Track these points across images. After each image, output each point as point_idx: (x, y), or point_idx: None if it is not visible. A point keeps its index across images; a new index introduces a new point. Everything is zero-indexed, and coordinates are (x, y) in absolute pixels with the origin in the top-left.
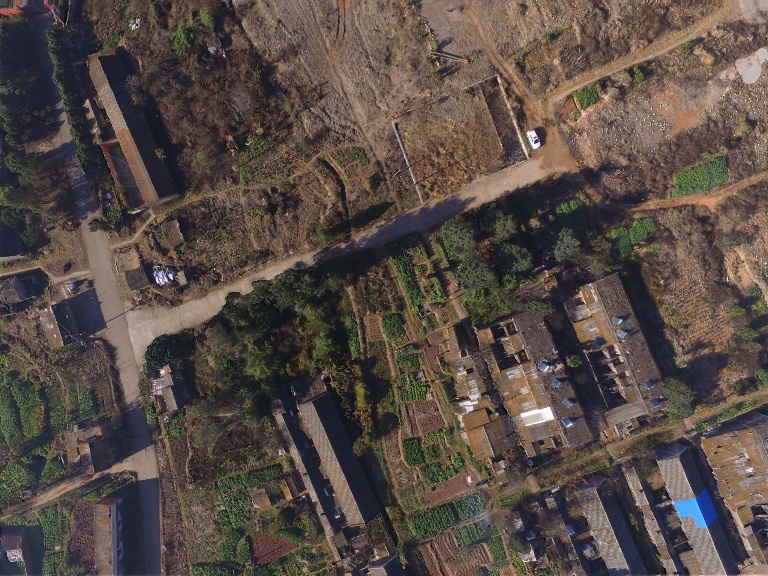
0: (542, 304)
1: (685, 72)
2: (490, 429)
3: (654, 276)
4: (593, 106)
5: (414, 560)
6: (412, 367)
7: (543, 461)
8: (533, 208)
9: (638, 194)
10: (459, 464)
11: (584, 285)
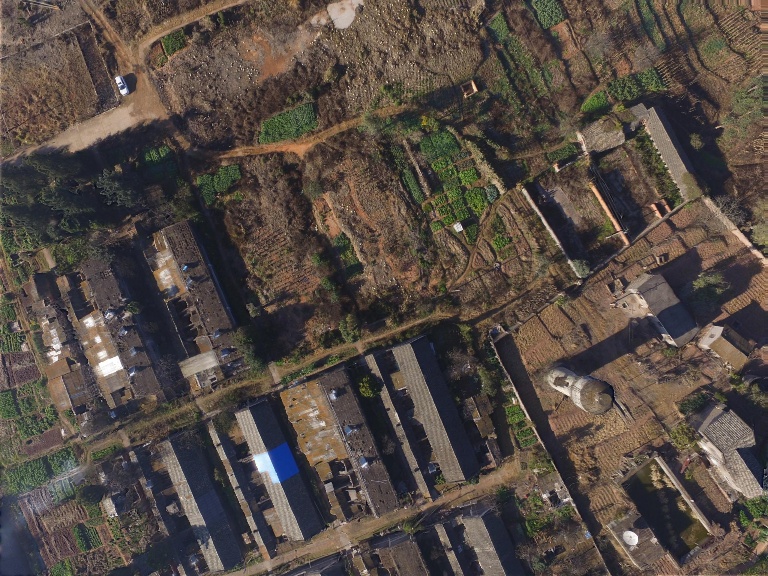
0: (97, 248)
1: (274, 17)
2: (69, 379)
3: (235, 224)
4: (178, 51)
5: (12, 515)
6: (9, 317)
7: (128, 413)
8: (123, 156)
9: (226, 141)
10: (51, 416)
11: (157, 232)
